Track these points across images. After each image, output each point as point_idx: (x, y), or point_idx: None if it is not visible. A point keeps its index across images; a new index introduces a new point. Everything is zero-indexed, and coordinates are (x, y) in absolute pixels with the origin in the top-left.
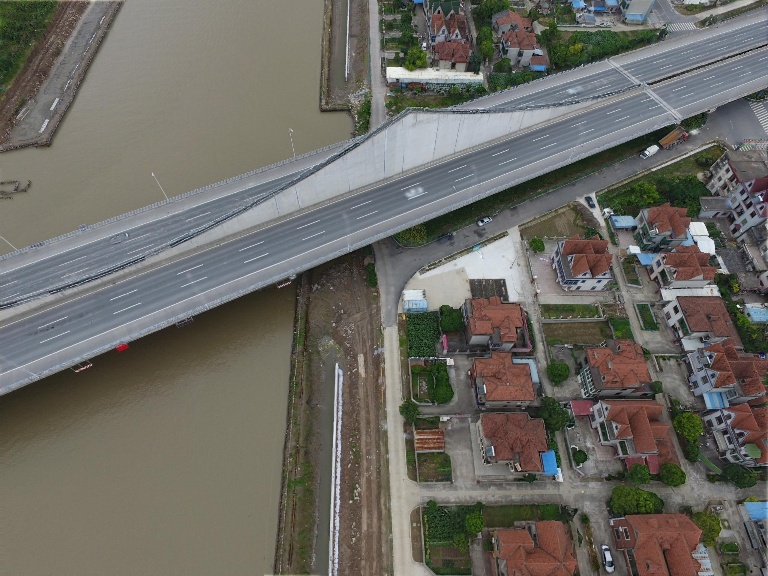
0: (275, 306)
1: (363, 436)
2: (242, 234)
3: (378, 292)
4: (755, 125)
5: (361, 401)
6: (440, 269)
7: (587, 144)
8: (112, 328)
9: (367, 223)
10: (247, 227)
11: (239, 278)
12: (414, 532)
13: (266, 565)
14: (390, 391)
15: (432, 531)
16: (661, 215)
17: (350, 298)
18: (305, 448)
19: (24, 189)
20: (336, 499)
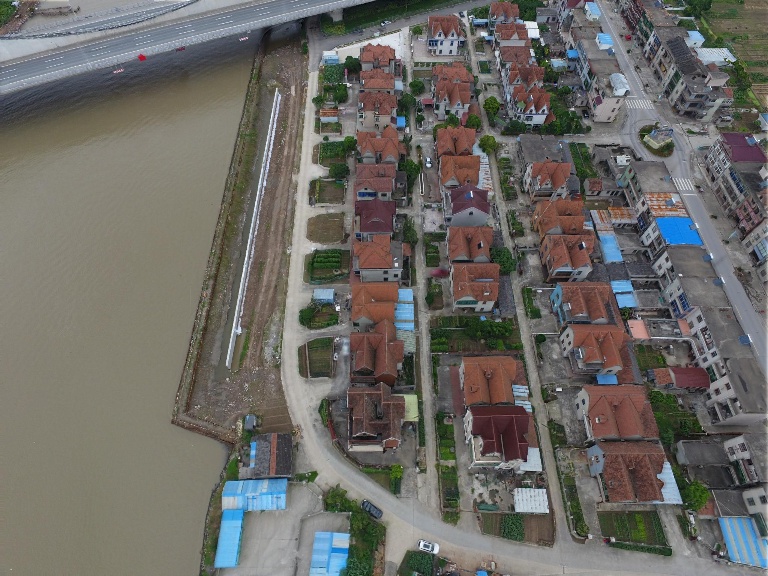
0: (239, 58)
1: (290, 119)
2: (218, 12)
3: (308, 56)
4: None
5: (291, 105)
6: (351, 46)
7: None
8: (135, 50)
9: (300, 8)
10: (221, 7)
11: (215, 31)
12: (314, 153)
13: (225, 167)
14: (309, 98)
15: (325, 151)
16: (499, 7)
17: (290, 61)
18: (253, 123)
19: (75, 10)
20: (270, 145)
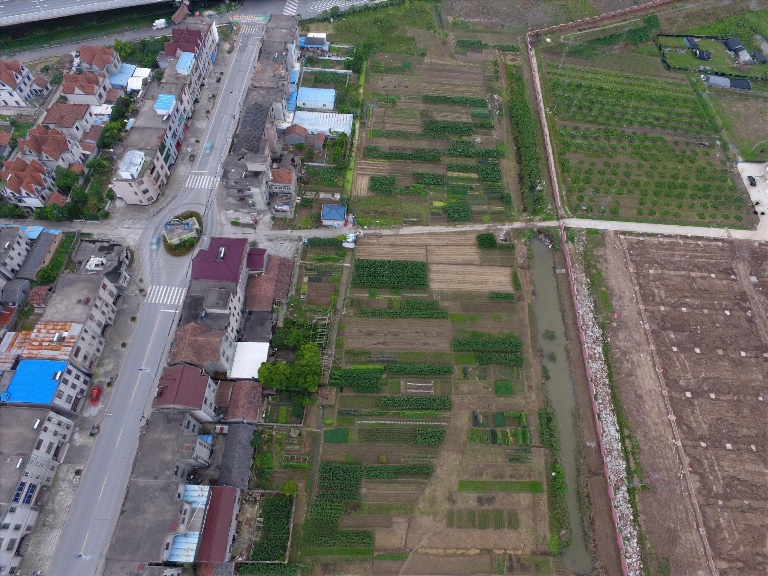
0: None
1: None
2: None
3: None
4: (276, 14)
5: None
6: None
7: (77, 7)
8: None
9: None
10: None
11: None
12: None
13: None
14: None
15: None
16: None
17: None
18: None
19: None
20: None
